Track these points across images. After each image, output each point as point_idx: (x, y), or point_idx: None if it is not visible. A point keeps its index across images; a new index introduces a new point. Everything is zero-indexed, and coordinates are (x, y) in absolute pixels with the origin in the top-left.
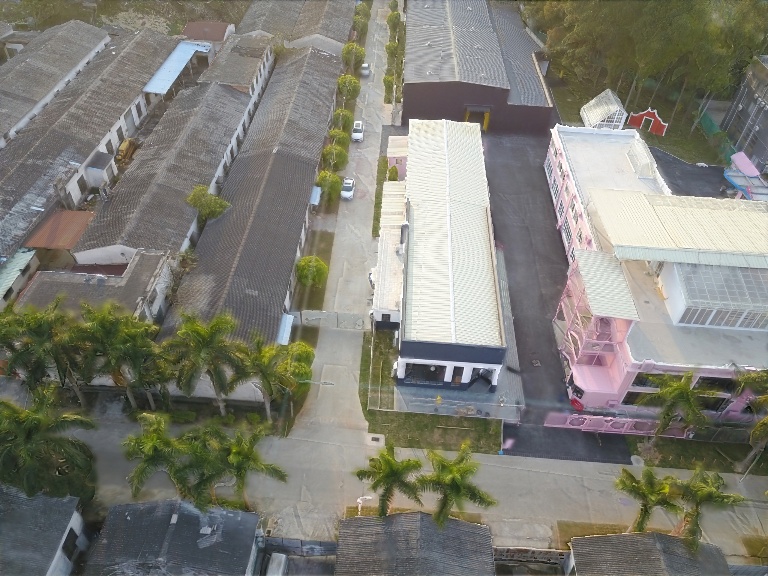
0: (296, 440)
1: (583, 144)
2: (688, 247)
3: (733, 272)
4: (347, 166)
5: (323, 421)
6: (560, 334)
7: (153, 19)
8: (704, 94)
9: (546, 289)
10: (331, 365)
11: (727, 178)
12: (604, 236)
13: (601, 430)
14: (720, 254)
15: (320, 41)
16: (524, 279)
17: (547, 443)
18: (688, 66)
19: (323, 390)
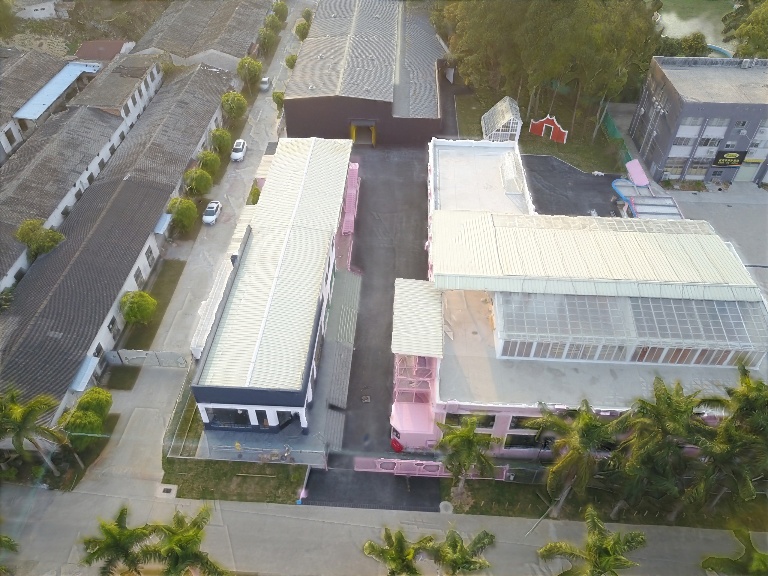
0: (81, 494)
1: (457, 158)
2: (514, 274)
3: (558, 300)
4: (220, 188)
5: (116, 472)
6: None
7: (51, 39)
8: (613, 97)
9: None
10: (143, 408)
11: (614, 188)
12: None
13: (415, 473)
14: (547, 281)
15: (216, 56)
16: (377, 306)
17: (353, 490)
18: (577, 71)
19: (126, 436)
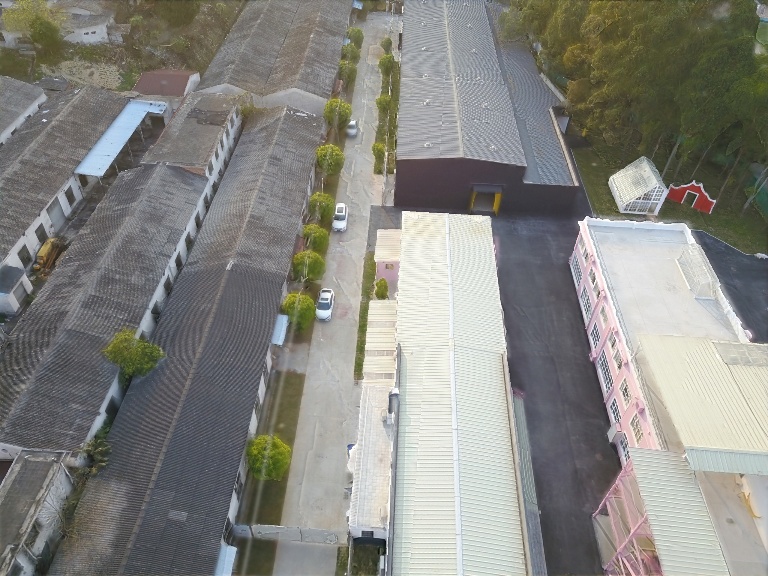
0: None
1: (621, 245)
2: None
3: None
4: (326, 268)
5: None
6: (604, 540)
7: (103, 68)
8: None
9: (581, 461)
10: None
11: None
12: (660, 399)
13: None
14: None
15: (298, 96)
16: (551, 444)
17: None
18: (746, 137)
19: None
